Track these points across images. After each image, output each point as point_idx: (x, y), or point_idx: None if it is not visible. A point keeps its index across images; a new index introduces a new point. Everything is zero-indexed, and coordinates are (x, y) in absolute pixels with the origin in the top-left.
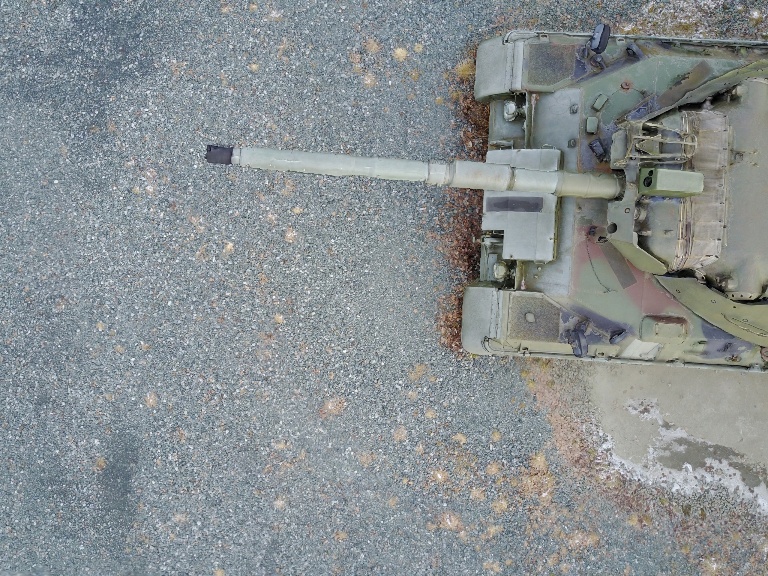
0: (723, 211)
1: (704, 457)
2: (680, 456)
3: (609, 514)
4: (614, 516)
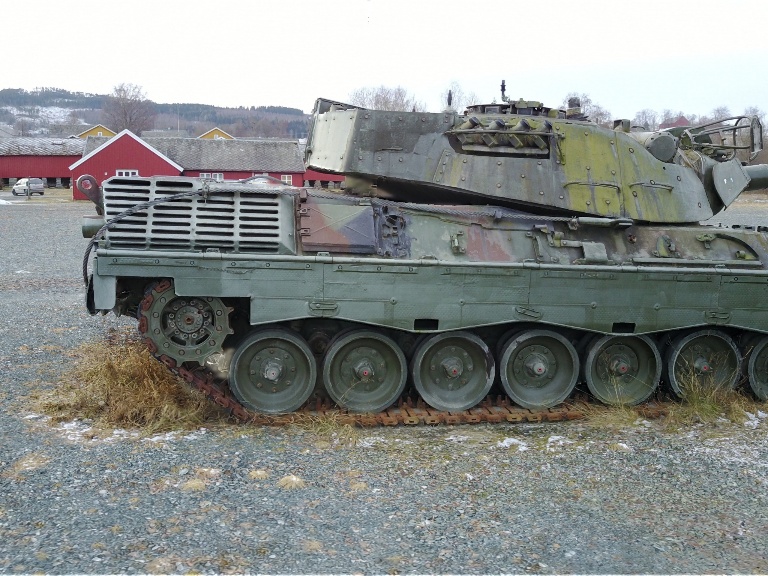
0: None
1: None
2: None
3: None
4: None
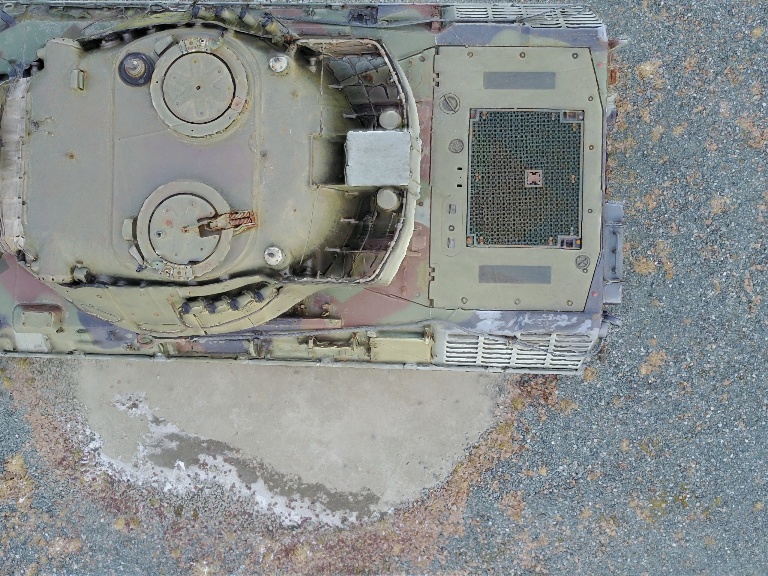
0: (21, 186)
1: (197, 453)
2: (172, 453)
3: (94, 518)
4: (99, 520)
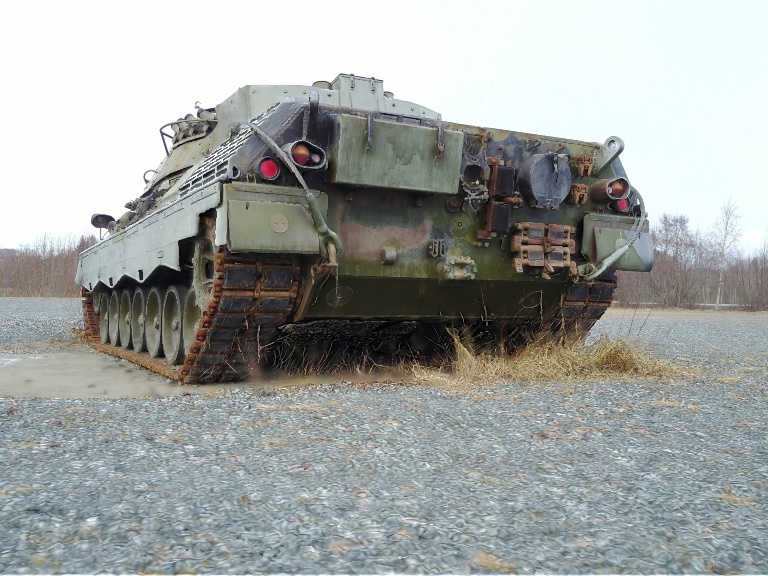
0: None
1: None
2: None
3: None
4: None
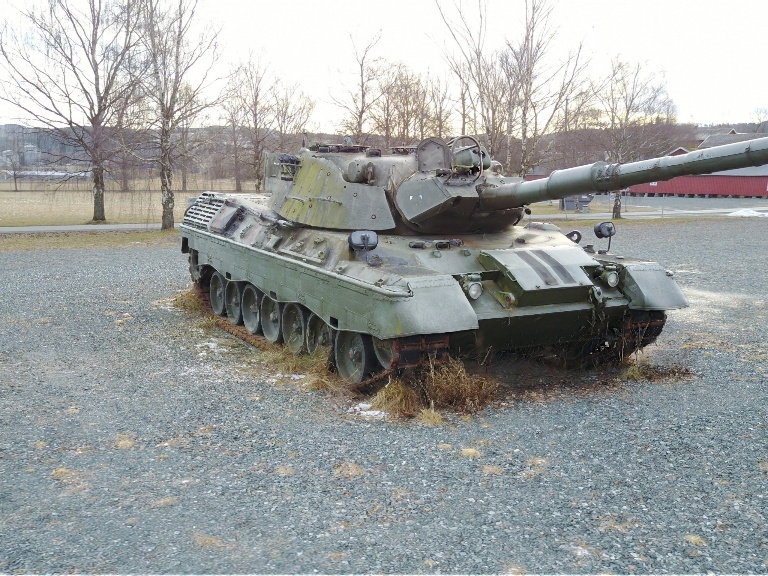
0: None
1: None
2: None
3: None
4: None
